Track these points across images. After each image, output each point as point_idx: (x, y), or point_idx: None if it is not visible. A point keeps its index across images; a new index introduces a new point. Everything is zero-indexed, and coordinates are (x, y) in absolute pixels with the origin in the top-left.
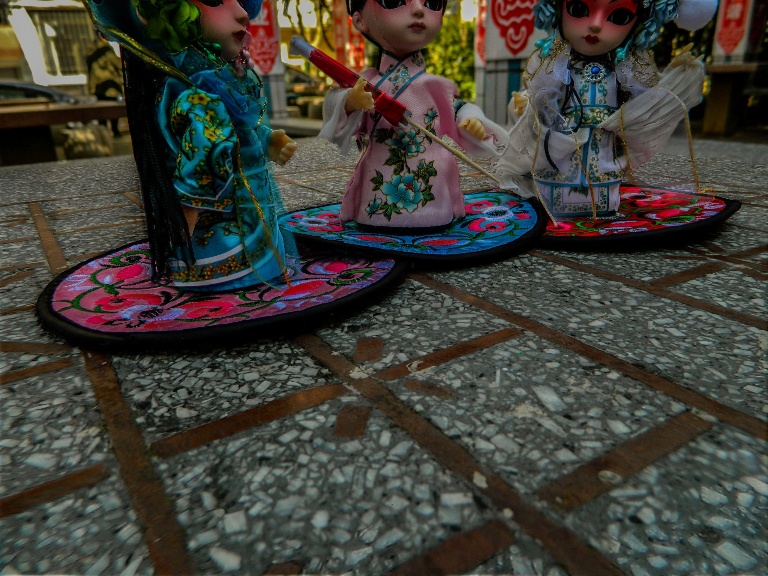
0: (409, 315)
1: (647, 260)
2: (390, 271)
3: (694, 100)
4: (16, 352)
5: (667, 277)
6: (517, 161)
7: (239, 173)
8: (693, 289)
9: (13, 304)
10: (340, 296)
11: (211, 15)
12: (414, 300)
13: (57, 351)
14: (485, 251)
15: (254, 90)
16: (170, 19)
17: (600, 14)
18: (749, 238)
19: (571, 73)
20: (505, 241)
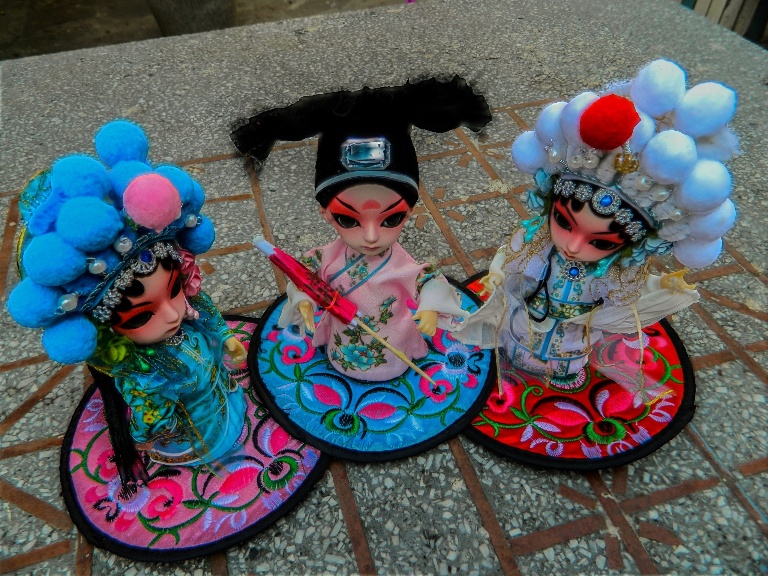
0: (299, 544)
1: (541, 492)
2: (306, 478)
3: (686, 305)
4: (41, 519)
5: (533, 535)
6: (484, 320)
7: (186, 408)
8: (538, 567)
9: (51, 431)
10: (250, 523)
11: (142, 333)
12: (314, 517)
13: (64, 527)
14: (400, 454)
15: (204, 325)
16: (105, 352)
17: (580, 239)
18: (672, 465)
19: (553, 259)
20: (427, 436)
